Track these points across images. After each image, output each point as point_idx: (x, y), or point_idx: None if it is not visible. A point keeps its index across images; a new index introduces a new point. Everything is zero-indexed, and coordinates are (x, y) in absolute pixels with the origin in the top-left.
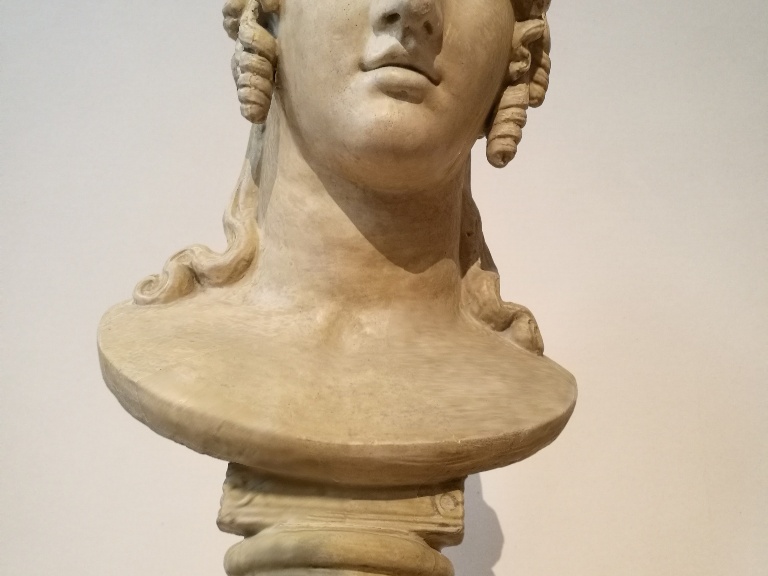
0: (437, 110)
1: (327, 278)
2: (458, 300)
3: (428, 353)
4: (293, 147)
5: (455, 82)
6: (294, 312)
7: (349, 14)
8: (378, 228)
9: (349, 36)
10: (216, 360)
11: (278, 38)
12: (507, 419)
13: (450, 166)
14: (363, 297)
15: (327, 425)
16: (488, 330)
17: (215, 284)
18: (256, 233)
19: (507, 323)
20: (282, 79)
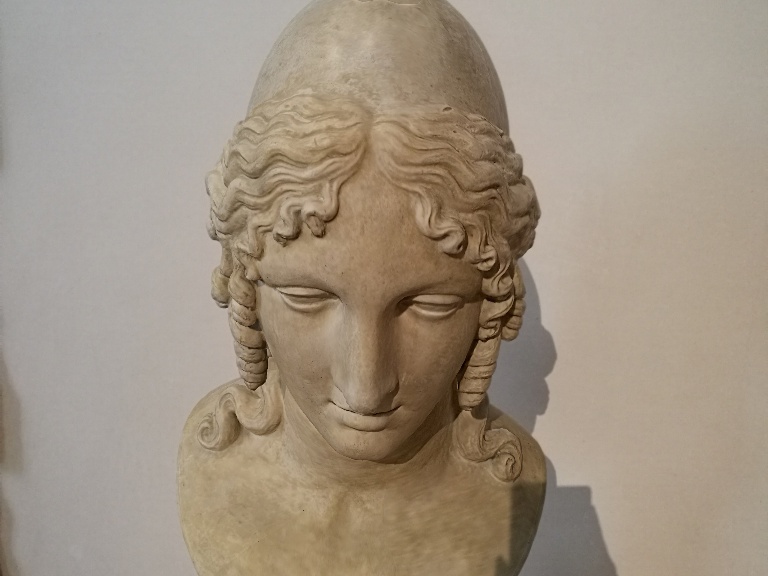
0: (399, 426)
1: (334, 473)
2: (448, 446)
3: (413, 526)
4: None
5: (414, 404)
6: (312, 488)
7: (314, 370)
8: None
9: (316, 383)
10: (256, 560)
11: None
12: None
13: None
14: (363, 484)
15: None
16: (473, 465)
17: None
18: (280, 402)
19: (490, 457)
20: None
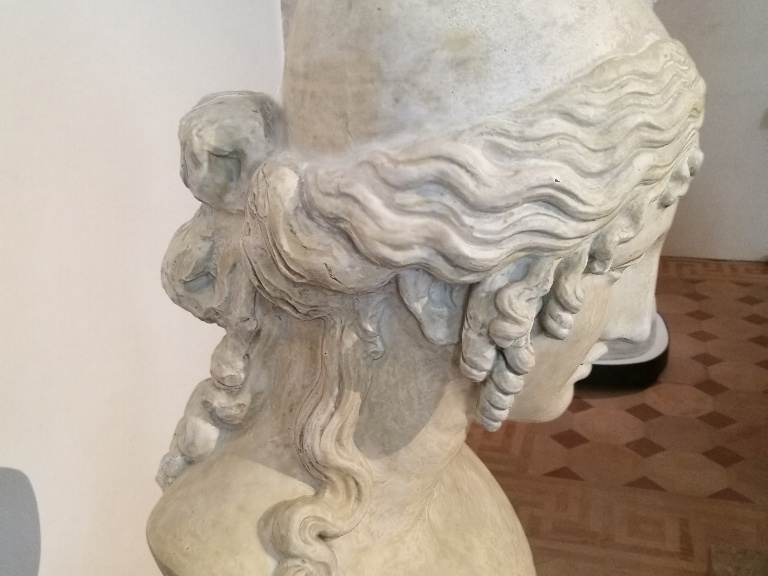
0: None
1: None
2: None
3: (448, 480)
4: None
5: None
6: None
7: None
8: None
9: None
10: None
11: None
12: (512, 512)
13: None
14: None
15: None
16: None
17: None
18: None
19: None
20: None
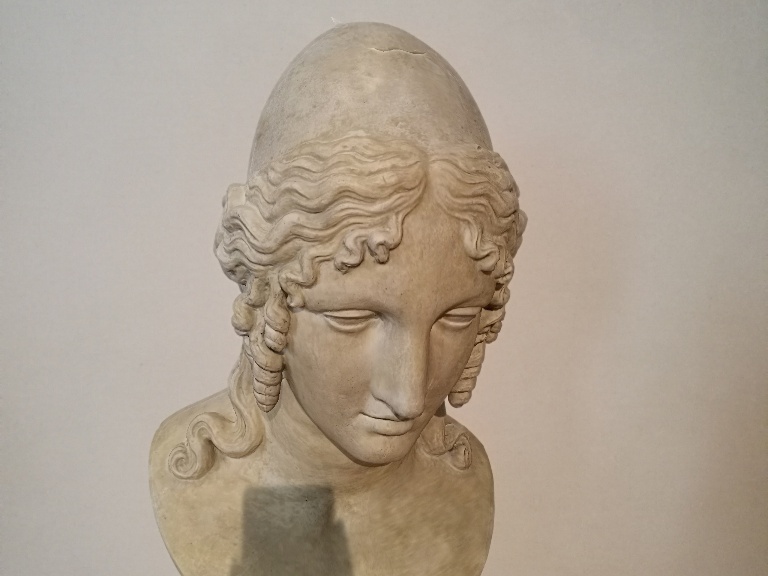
0: None
1: (326, 483)
2: (415, 444)
3: (397, 520)
4: (296, 403)
5: (432, 406)
6: (301, 501)
7: (353, 385)
8: None
9: (352, 397)
10: None
11: (285, 355)
12: None
13: None
14: (351, 489)
15: None
16: (435, 459)
17: (233, 457)
18: (262, 423)
19: (448, 450)
20: (289, 378)
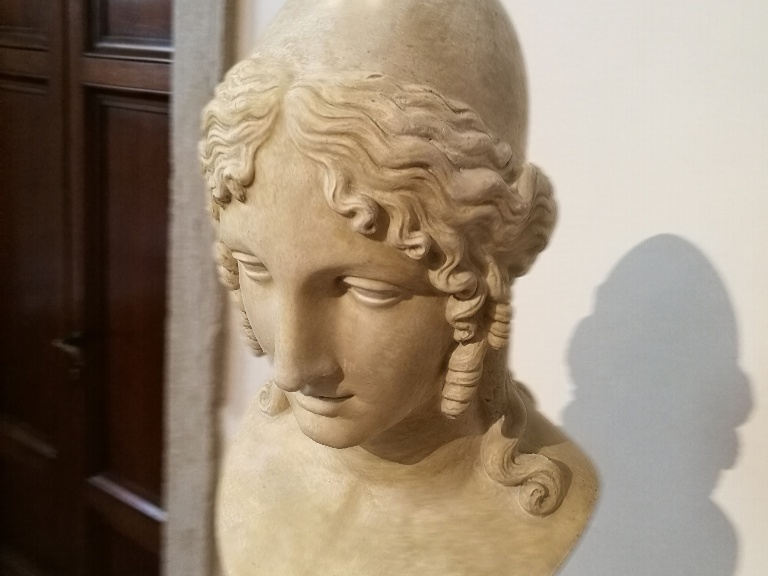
0: (355, 417)
1: (344, 459)
2: (473, 460)
3: (415, 534)
4: None
5: (366, 396)
6: (331, 470)
7: (267, 340)
8: (367, 441)
9: (273, 355)
10: (263, 525)
11: None
12: None
13: None
14: (371, 477)
15: None
16: (500, 487)
17: None
18: None
19: (519, 483)
20: None
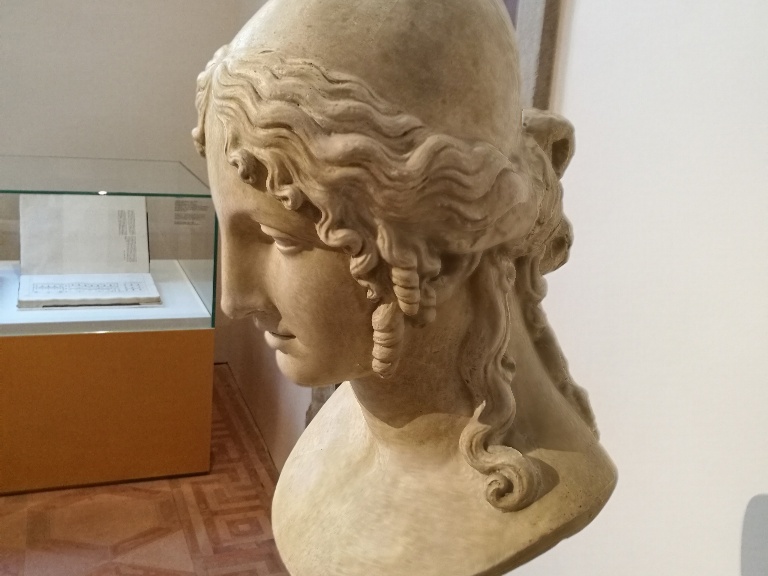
0: (300, 357)
1: None
2: None
3: (396, 495)
4: None
5: (300, 337)
6: None
7: None
8: (360, 396)
9: None
10: None
11: None
12: None
13: (362, 370)
14: None
15: (289, 546)
16: (477, 473)
17: None
18: None
19: None
20: None
